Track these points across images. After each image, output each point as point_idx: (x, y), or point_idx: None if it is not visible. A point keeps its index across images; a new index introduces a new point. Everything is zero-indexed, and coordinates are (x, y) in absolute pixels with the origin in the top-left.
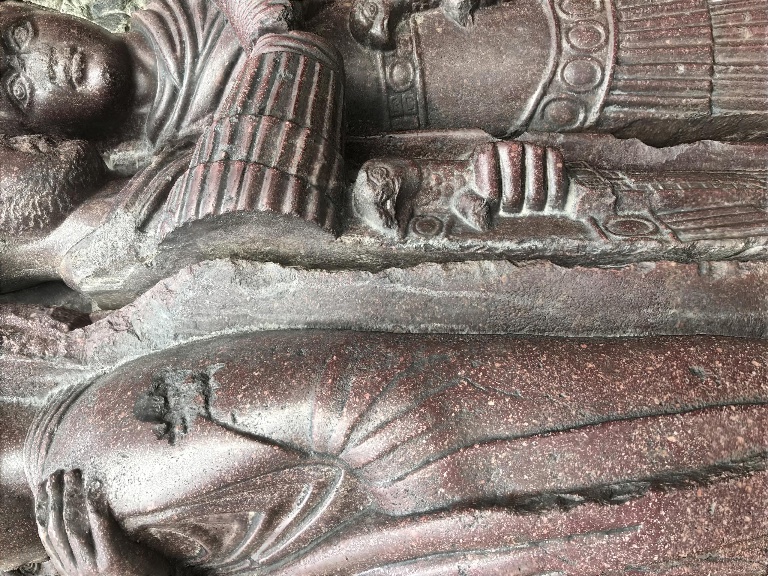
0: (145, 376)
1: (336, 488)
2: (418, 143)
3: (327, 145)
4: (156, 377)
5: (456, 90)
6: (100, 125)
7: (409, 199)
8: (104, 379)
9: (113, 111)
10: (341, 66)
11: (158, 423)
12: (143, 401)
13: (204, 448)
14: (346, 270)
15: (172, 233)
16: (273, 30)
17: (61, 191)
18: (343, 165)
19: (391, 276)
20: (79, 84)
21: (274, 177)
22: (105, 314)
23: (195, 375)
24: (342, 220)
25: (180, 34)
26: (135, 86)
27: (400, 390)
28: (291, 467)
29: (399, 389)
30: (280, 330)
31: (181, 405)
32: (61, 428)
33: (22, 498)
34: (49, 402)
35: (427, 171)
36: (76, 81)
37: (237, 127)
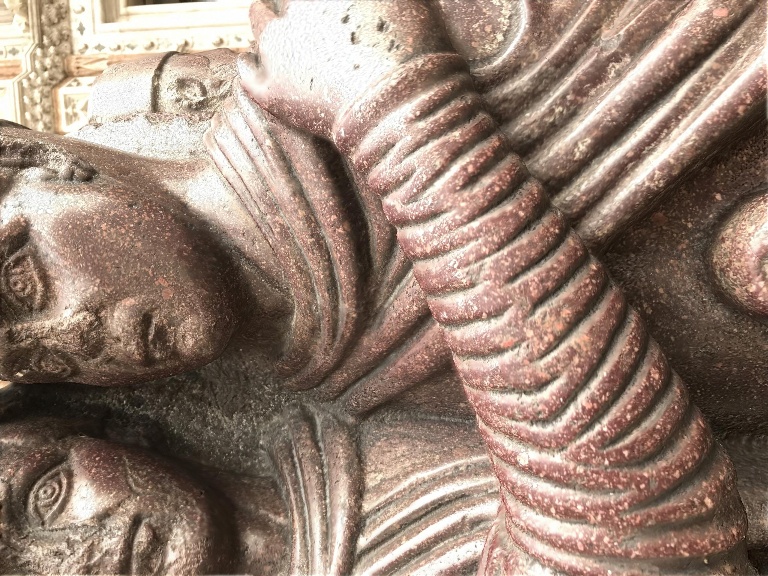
0: None
1: None
2: None
3: None
4: None
5: None
6: None
7: None
8: None
9: None
10: None
11: None
12: None
13: None
14: None
15: None
16: None
17: None
18: None
19: None
20: None
21: None
22: None
23: None
24: None
25: None
26: None
27: None
28: None
29: None
30: None
31: None
32: None
33: (171, 194)
34: None
35: None
36: None
37: None
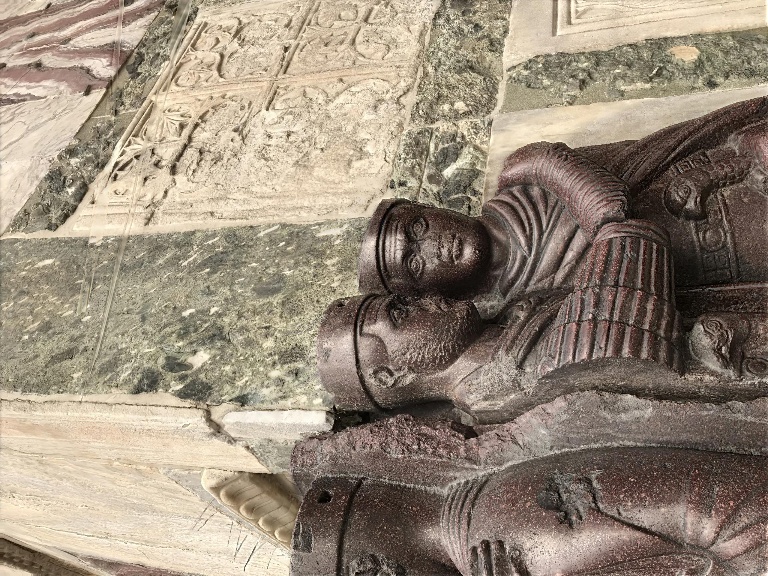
0: (539, 476)
1: (706, 575)
2: (735, 294)
3: (670, 306)
4: (548, 478)
5: (765, 247)
6: (465, 285)
7: (739, 345)
8: (503, 477)
9: (477, 275)
10: (669, 241)
11: (558, 511)
12: (542, 495)
13: (598, 533)
14: (692, 402)
15: (552, 372)
16: (613, 218)
17: (458, 338)
18: (681, 319)
19: (732, 408)
20: (457, 259)
21: (633, 332)
22: (485, 427)
23: (580, 478)
24: (684, 362)
25: (528, 218)
26: (492, 256)
27: (759, 500)
28: (667, 554)
29: (758, 499)
30: (639, 447)
31: (573, 500)
32: (477, 510)
33: (436, 562)
34: (452, 491)
35: (755, 323)
36: (455, 257)
37: (599, 295)
